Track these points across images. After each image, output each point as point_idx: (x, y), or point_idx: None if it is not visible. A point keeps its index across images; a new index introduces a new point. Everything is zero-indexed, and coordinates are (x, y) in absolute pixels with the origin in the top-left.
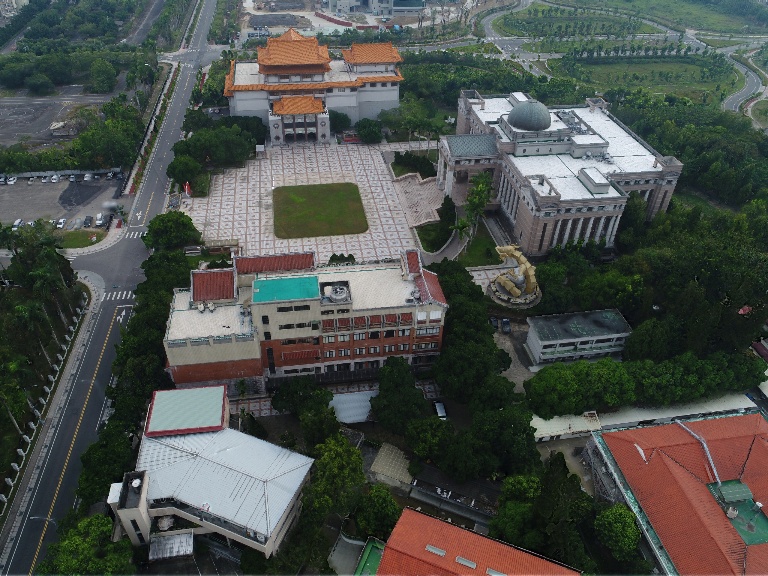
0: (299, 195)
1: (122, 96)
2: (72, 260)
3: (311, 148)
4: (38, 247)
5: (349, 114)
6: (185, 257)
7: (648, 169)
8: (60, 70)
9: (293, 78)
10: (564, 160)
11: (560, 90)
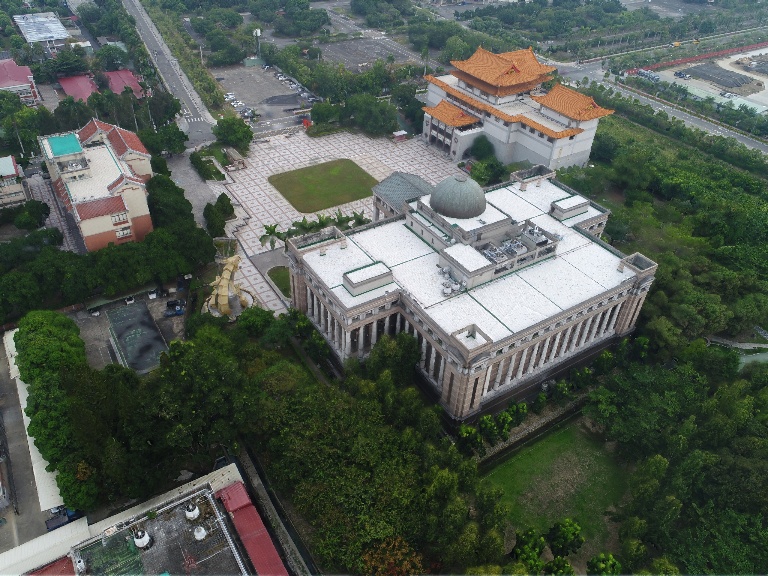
0: (342, 170)
1: (390, 57)
2: (198, 120)
3: (436, 157)
4: (161, 93)
5: (498, 148)
6: (176, 136)
7: (456, 329)
8: (441, 38)
9: (476, 90)
10: (424, 258)
11: (761, 265)
